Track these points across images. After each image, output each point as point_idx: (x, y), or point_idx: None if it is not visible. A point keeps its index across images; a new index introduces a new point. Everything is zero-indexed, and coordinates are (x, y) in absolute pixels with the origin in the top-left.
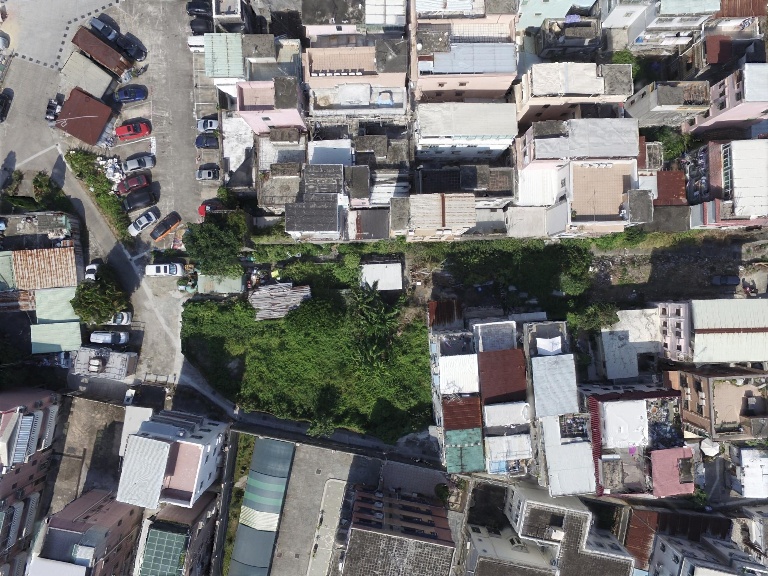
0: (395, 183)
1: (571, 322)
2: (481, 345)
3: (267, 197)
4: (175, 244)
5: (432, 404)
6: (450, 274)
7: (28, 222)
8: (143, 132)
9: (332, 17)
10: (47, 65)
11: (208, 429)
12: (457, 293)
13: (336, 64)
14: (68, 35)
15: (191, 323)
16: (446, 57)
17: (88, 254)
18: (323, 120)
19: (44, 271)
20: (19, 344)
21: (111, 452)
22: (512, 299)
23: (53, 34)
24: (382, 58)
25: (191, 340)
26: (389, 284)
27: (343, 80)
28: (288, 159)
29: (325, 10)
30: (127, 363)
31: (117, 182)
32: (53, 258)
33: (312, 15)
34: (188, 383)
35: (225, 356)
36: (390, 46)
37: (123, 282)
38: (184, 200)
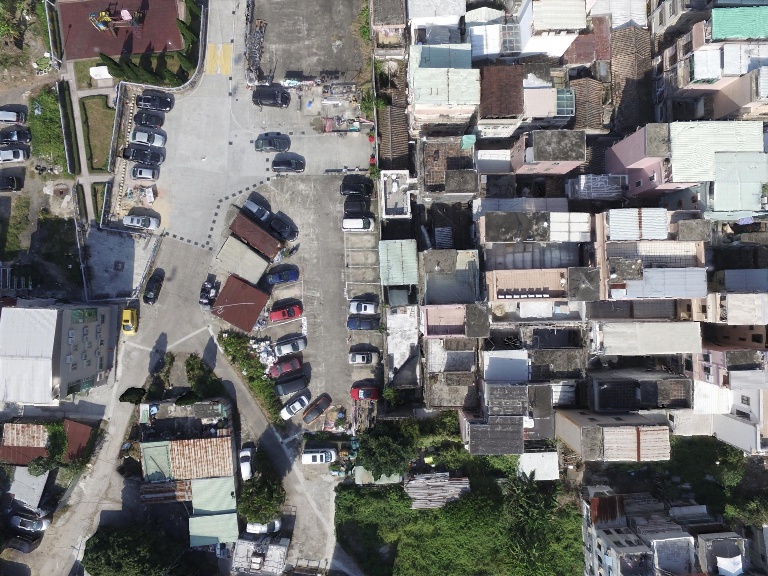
0: (561, 382)
1: (728, 513)
2: (656, 558)
3: (435, 399)
4: (326, 427)
5: None
6: None
7: None
8: (296, 315)
9: (516, 234)
10: (198, 244)
11: None
12: (609, 476)
13: (521, 283)
14: (219, 214)
15: (347, 513)
16: (638, 284)
17: (240, 437)
18: None
19: (200, 461)
20: (171, 529)
21: None
22: (671, 492)
23: (204, 213)
24: (575, 286)
25: (343, 525)
26: (546, 474)
27: (529, 301)
28: (457, 361)
29: (509, 227)
30: (285, 556)
31: (270, 365)
32: (210, 448)
33: (496, 232)
34: (339, 568)
35: (378, 543)
36: (583, 274)
37: (274, 465)
38: (335, 381)
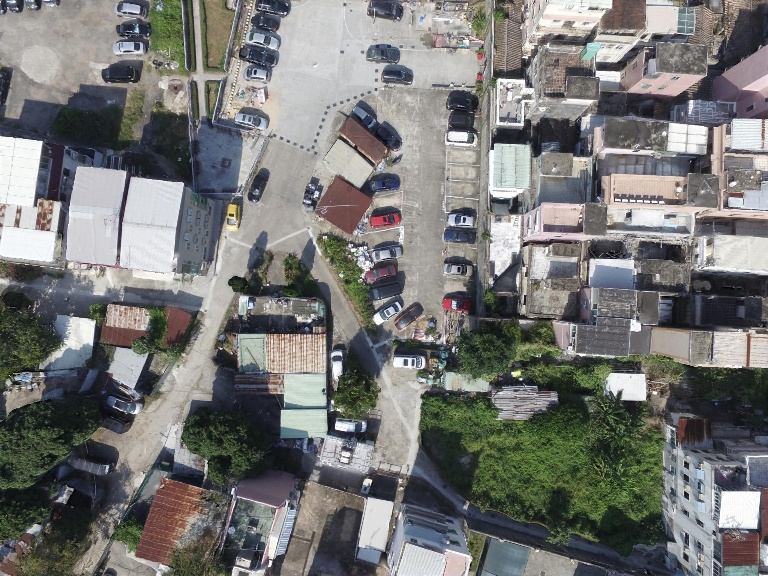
0: None
1: None
2: (748, 475)
3: (536, 306)
4: (417, 335)
5: (662, 516)
6: (689, 387)
7: (277, 303)
8: (396, 222)
9: (634, 142)
10: (303, 148)
11: (453, 530)
12: (692, 405)
13: (636, 189)
14: (326, 120)
15: (434, 418)
16: (755, 195)
17: (331, 339)
18: (605, 237)
19: (295, 356)
20: (258, 423)
21: (339, 537)
22: (758, 421)
23: (311, 118)
24: (694, 192)
25: (427, 432)
26: (633, 395)
27: (644, 207)
28: (559, 270)
29: (628, 134)
30: (372, 455)
31: (366, 270)
32: (305, 344)
33: (615, 138)
34: (420, 475)
35: (461, 452)
36: None
37: None
38: (427, 291)
